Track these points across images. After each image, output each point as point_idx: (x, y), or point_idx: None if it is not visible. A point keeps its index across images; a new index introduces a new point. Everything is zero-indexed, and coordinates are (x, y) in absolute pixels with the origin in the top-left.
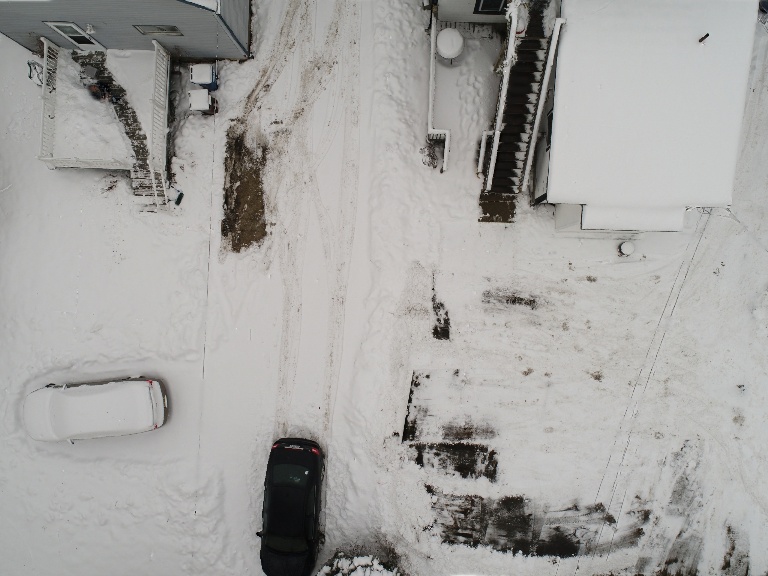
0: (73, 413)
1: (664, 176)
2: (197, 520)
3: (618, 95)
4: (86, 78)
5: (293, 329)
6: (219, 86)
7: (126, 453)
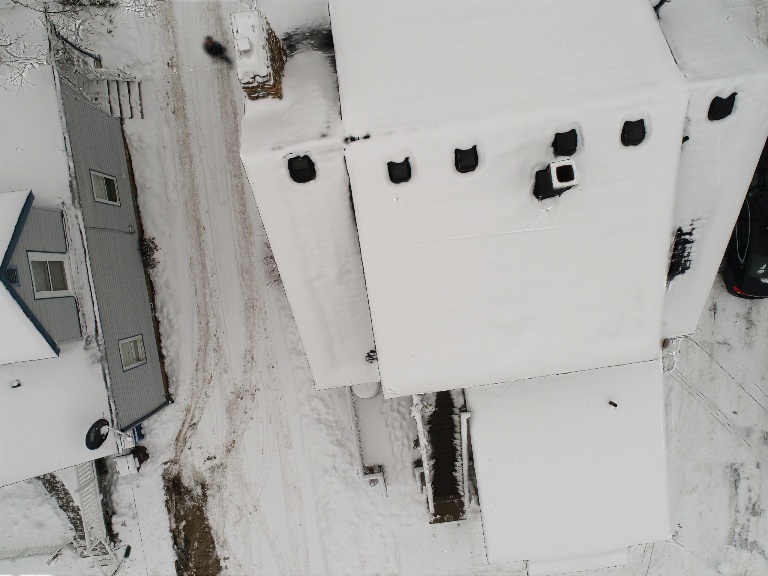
0: None
1: (600, 526)
2: None
3: (538, 463)
4: None
5: None
6: (145, 436)
7: None
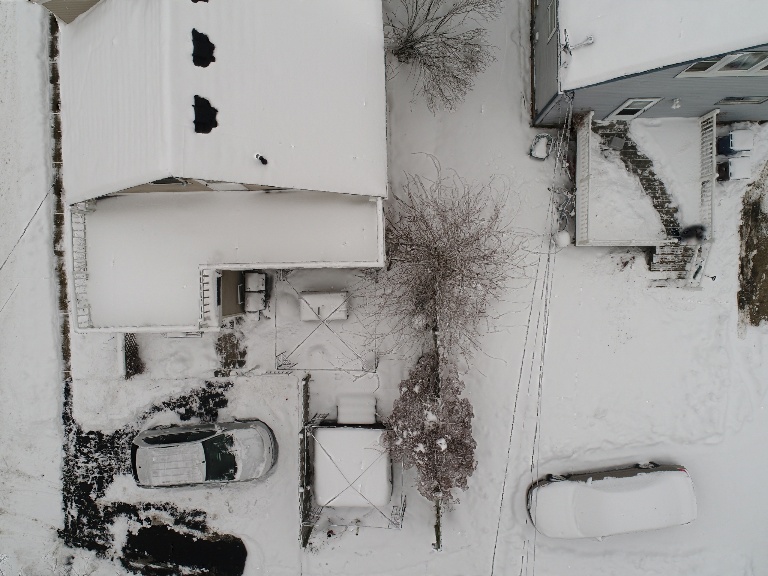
0: (613, 510)
1: None
2: None
3: None
4: (607, 150)
5: None
6: None
7: (636, 545)
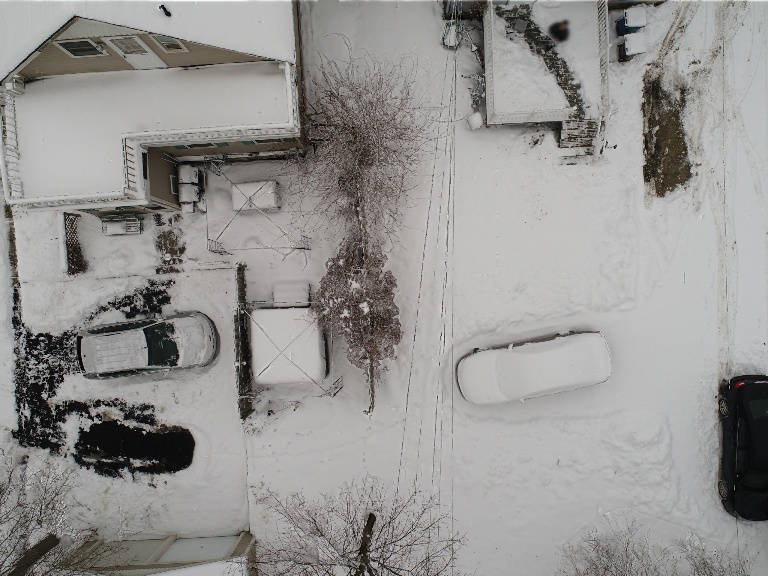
0: (532, 370)
1: None
2: (650, 469)
3: None
4: (512, 33)
5: (729, 268)
6: (637, 31)
7: (561, 410)
